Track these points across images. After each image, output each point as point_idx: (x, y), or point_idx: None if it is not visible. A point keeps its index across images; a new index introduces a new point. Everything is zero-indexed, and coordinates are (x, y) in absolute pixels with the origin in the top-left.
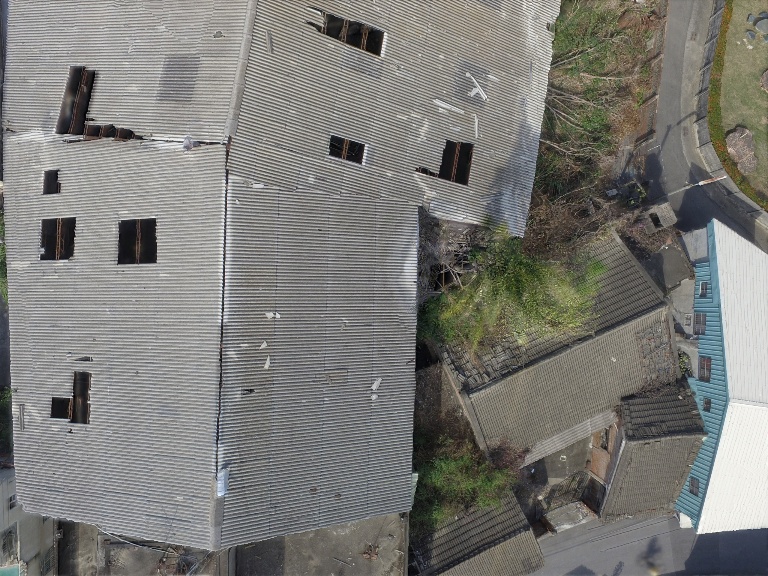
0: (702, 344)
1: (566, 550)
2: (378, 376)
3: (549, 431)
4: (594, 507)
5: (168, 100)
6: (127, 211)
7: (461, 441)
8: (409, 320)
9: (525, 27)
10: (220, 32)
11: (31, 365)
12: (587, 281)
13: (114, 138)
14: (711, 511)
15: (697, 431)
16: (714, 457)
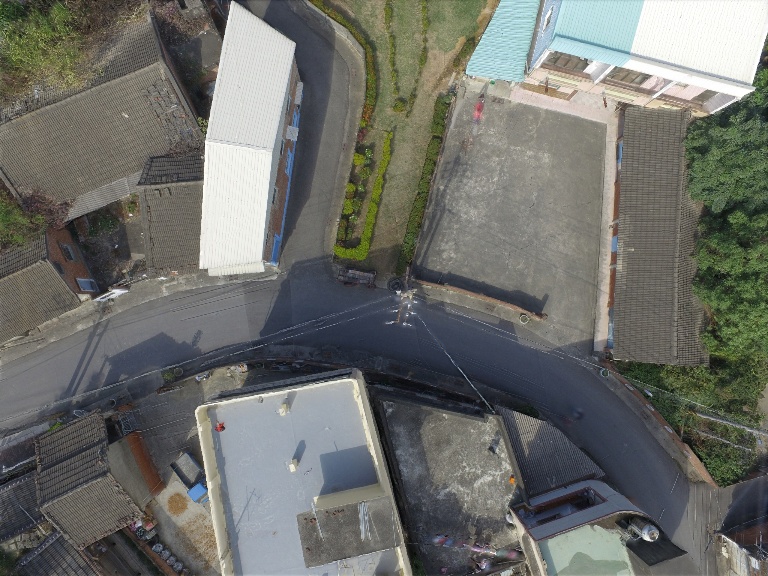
0: None
1: (148, 318)
2: None
3: (83, 185)
4: None
5: None
6: None
7: None
8: None
9: None
10: None
11: None
12: (111, 51)
13: None
14: (208, 247)
15: (201, 179)
16: None
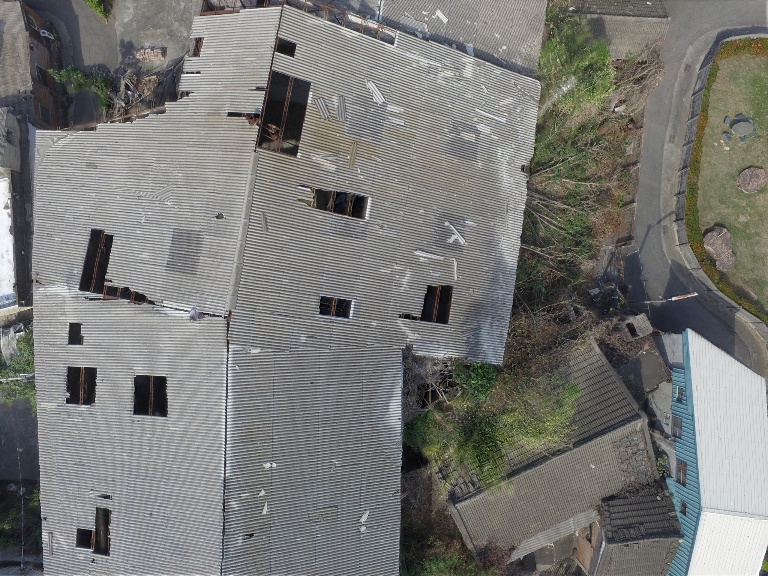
0: (679, 447)
1: None
2: (366, 509)
3: (533, 530)
4: None
5: (176, 271)
6: (141, 368)
7: (450, 542)
8: (394, 455)
9: (501, 172)
10: (221, 214)
11: (58, 498)
12: (567, 390)
13: (130, 300)
14: None
15: (674, 533)
16: (689, 561)
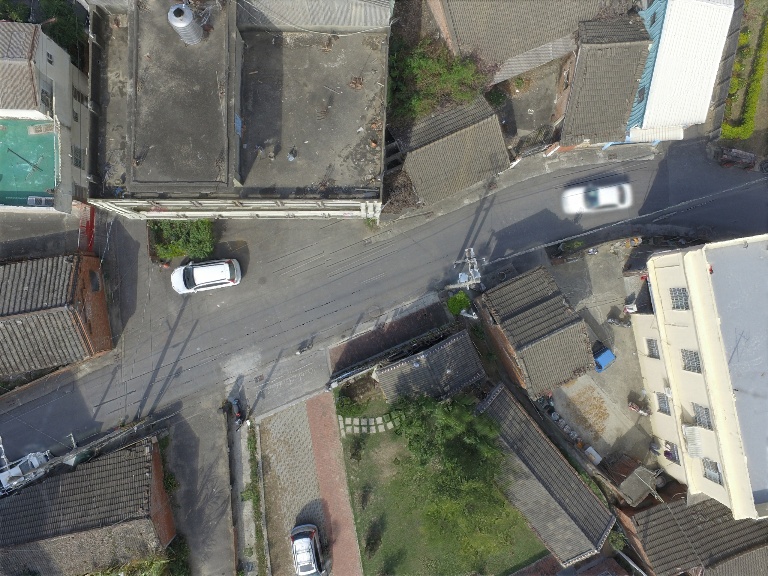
0: None
1: (532, 194)
2: None
3: (515, 48)
4: None
5: None
6: None
7: None
8: None
9: None
10: None
11: None
12: None
13: None
14: (654, 106)
15: (643, 40)
16: (657, 53)
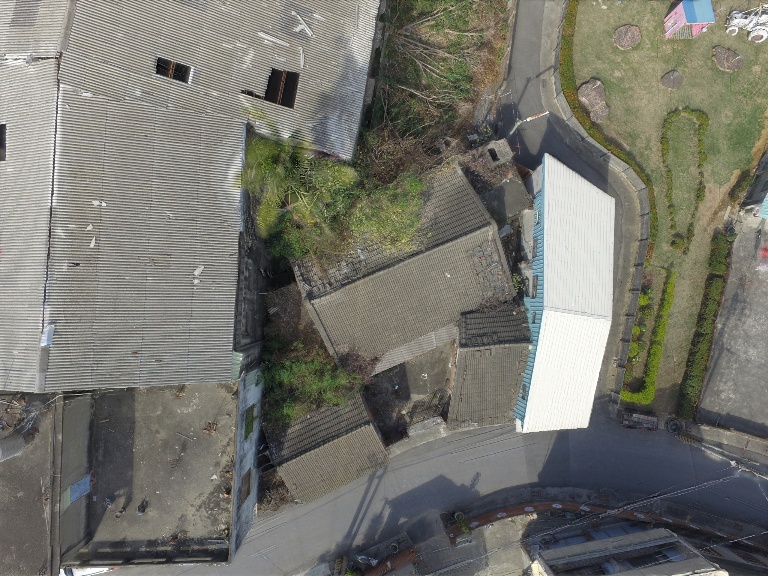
0: (535, 265)
1: (427, 460)
2: (200, 264)
3: (395, 341)
4: (446, 418)
5: (19, 26)
6: None
7: (312, 347)
8: (232, 219)
9: None
10: None
11: None
12: (428, 206)
13: None
14: (534, 411)
15: (523, 340)
16: (534, 361)
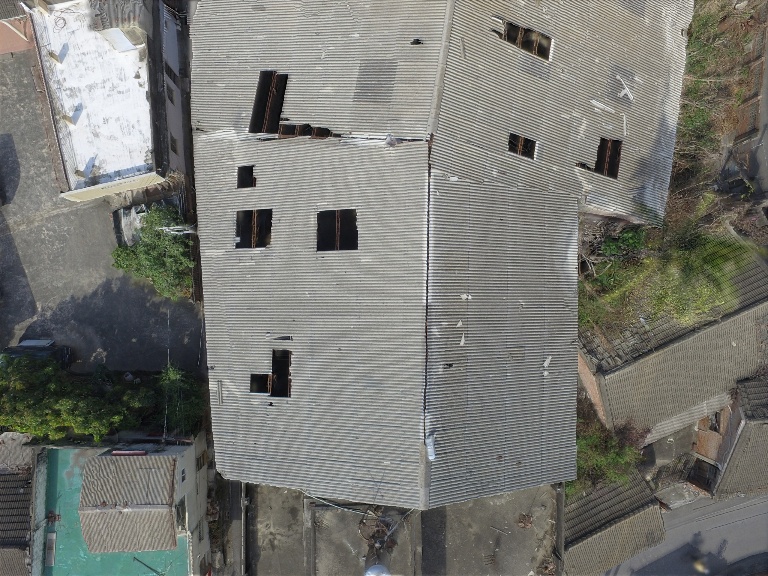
0: None
1: (673, 529)
2: (548, 354)
3: (670, 412)
4: (704, 487)
5: (366, 101)
6: (326, 203)
7: (589, 421)
8: (572, 303)
9: (664, 33)
10: (418, 40)
11: (228, 344)
12: (706, 271)
13: (311, 136)
14: None
15: None
16: None
